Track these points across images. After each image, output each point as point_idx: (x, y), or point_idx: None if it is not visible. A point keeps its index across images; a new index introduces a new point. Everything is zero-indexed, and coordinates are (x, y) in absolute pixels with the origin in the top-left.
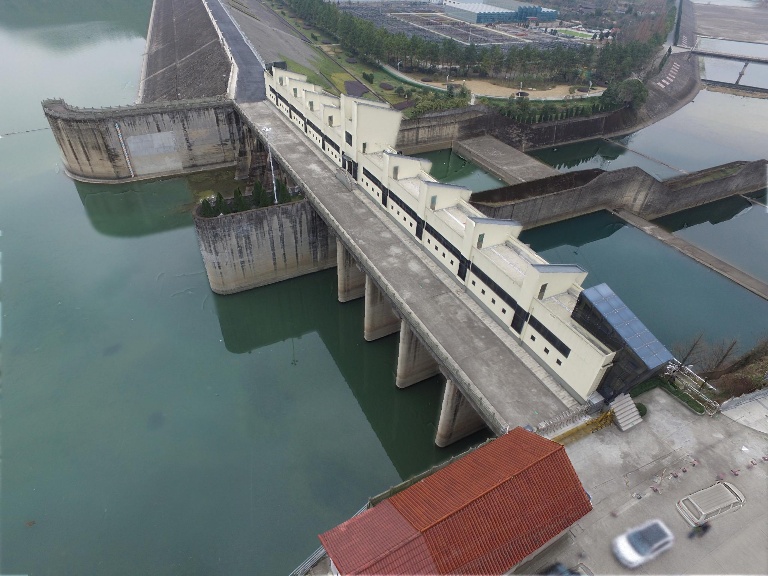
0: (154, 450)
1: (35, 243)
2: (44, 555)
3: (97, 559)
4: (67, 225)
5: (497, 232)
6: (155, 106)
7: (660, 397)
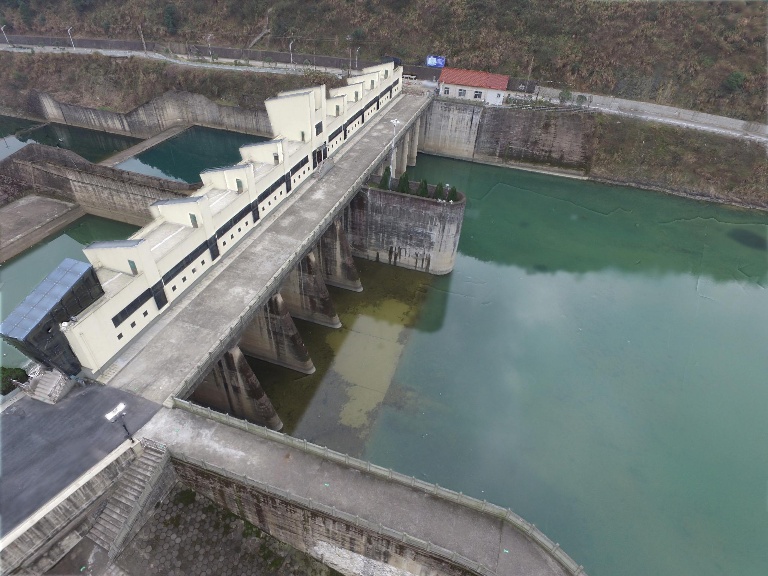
0: None
1: (622, 451)
2: None
3: None
4: (579, 473)
5: None
6: (330, 513)
7: None
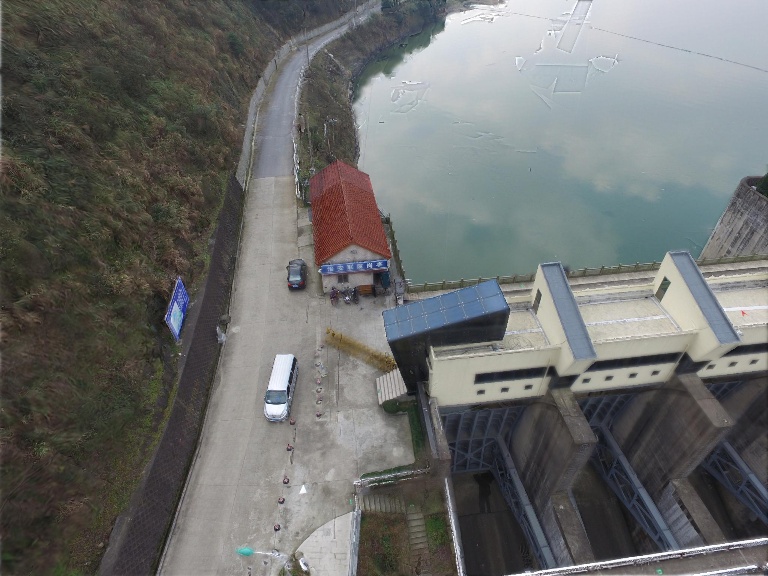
0: (511, 233)
1: (747, 171)
2: (455, 205)
3: (446, 218)
4: None
5: (685, 302)
6: None
7: (401, 454)
